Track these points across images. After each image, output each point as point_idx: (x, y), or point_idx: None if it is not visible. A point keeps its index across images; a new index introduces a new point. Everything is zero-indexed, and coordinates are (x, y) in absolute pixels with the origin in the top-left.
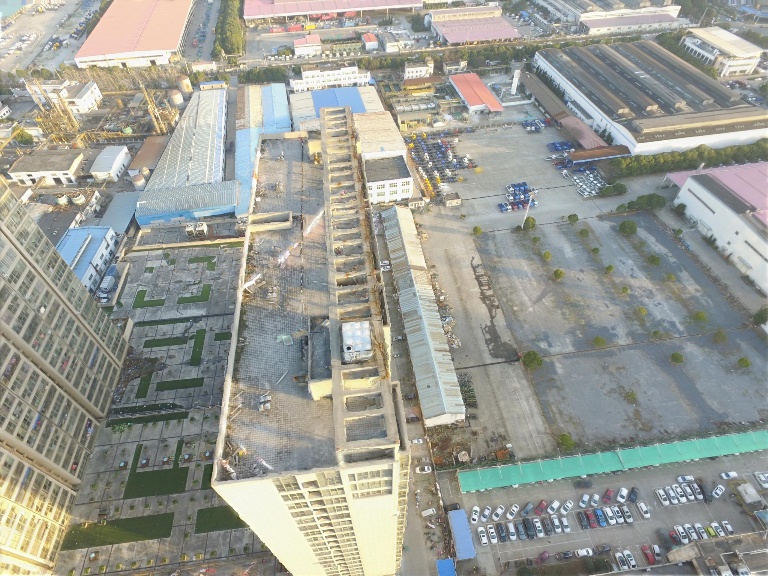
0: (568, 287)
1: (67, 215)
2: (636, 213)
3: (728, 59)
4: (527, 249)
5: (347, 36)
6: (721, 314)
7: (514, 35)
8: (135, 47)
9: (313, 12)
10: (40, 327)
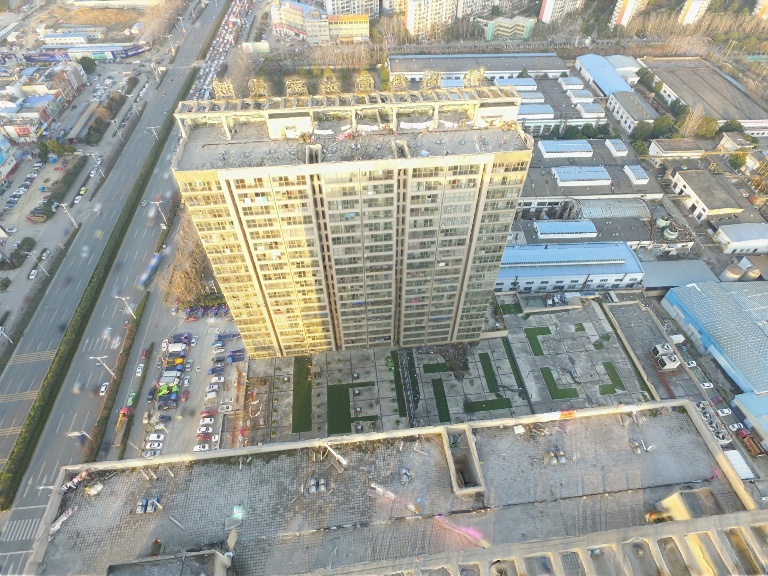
0: None
1: (644, 234)
2: None
3: None
4: None
5: None
6: None
7: None
8: None
9: None
10: (427, 270)
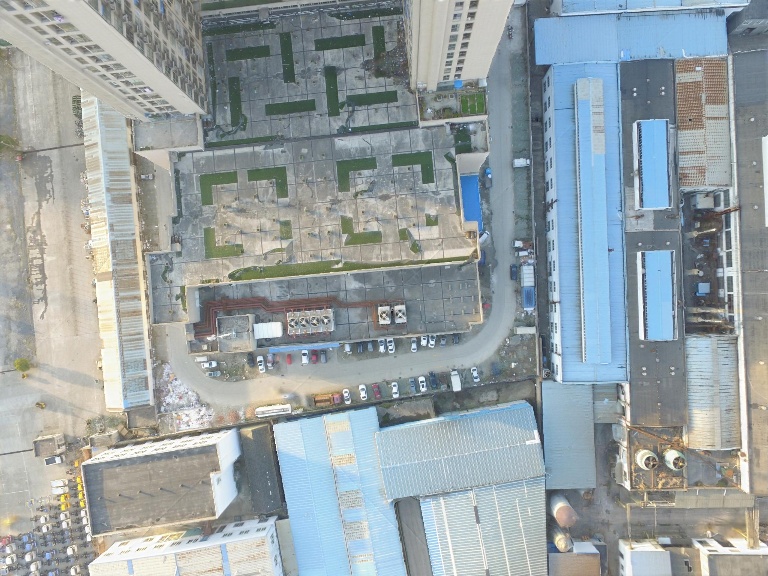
0: None
1: (647, 417)
2: None
3: None
4: None
5: None
6: None
7: None
8: None
9: None
10: None
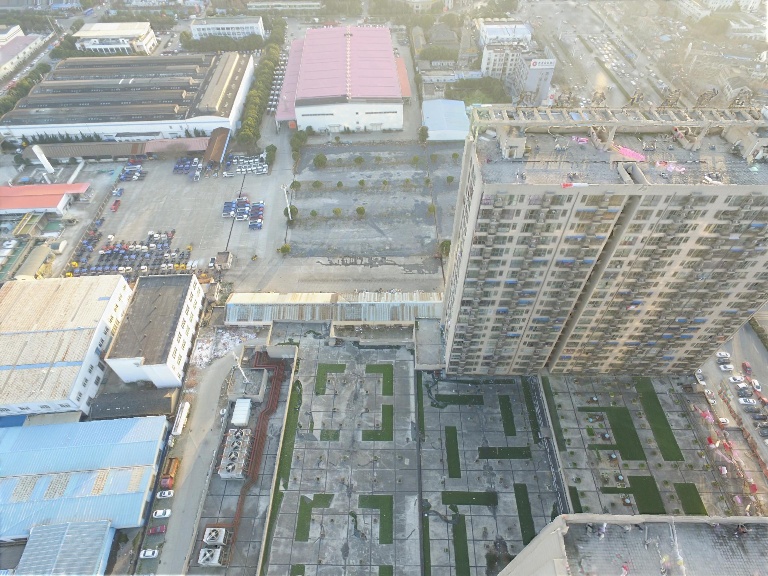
0: (371, 212)
1: None
2: (300, 153)
3: (139, 41)
4: (319, 224)
5: None
6: (412, 152)
7: None
8: None
9: None
10: None
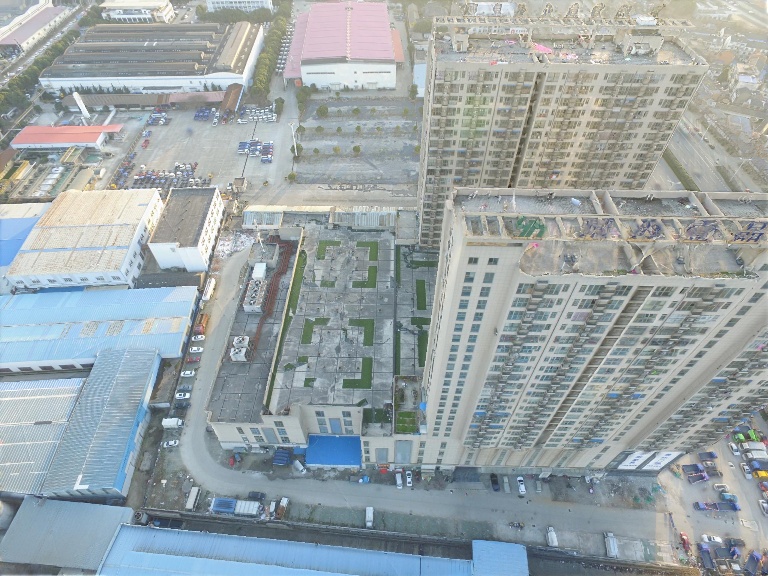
0: (366, 151)
1: None
2: (305, 106)
3: (159, 12)
4: (321, 160)
5: None
6: (403, 106)
7: None
8: None
9: None
10: None
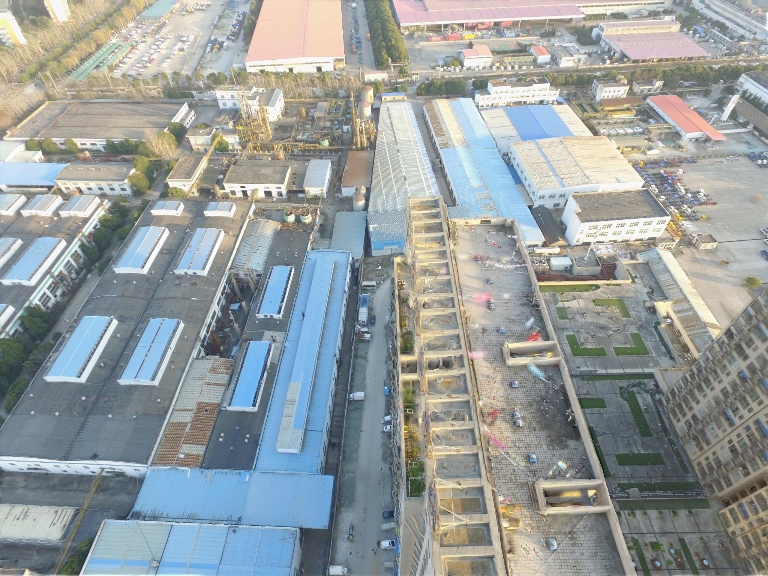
0: None
1: (301, 235)
2: None
3: None
4: None
5: (514, 48)
6: None
7: (702, 53)
8: (303, 53)
9: (471, 21)
10: None
